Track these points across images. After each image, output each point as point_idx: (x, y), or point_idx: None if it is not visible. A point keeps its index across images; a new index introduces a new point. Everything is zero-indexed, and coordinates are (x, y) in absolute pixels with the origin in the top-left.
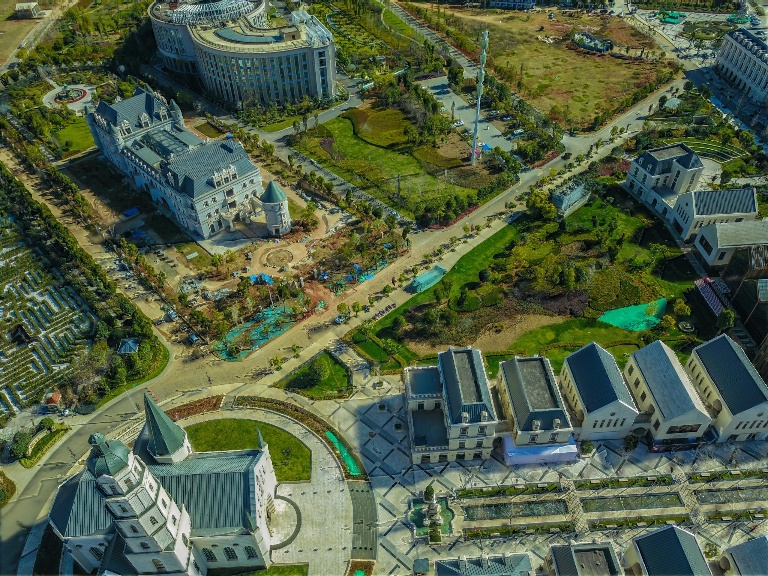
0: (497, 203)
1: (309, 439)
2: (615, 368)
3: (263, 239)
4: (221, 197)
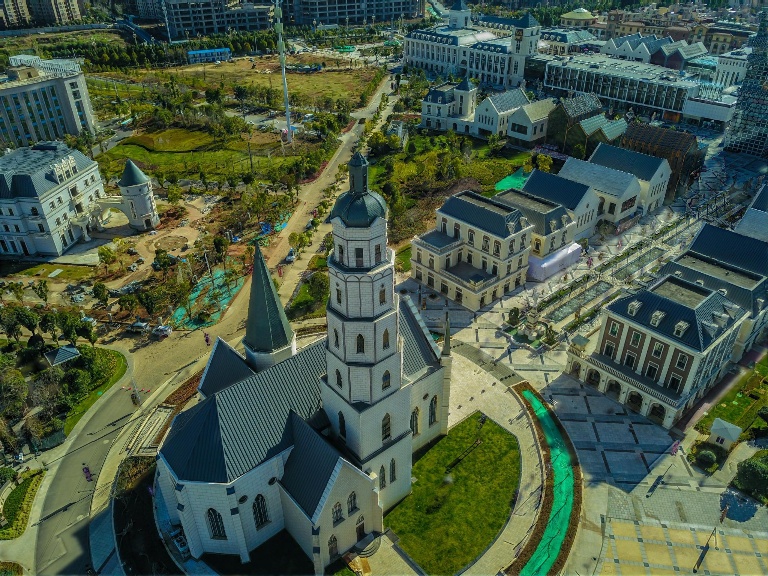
0: (340, 157)
1: None
2: None
3: (135, 236)
4: (66, 197)
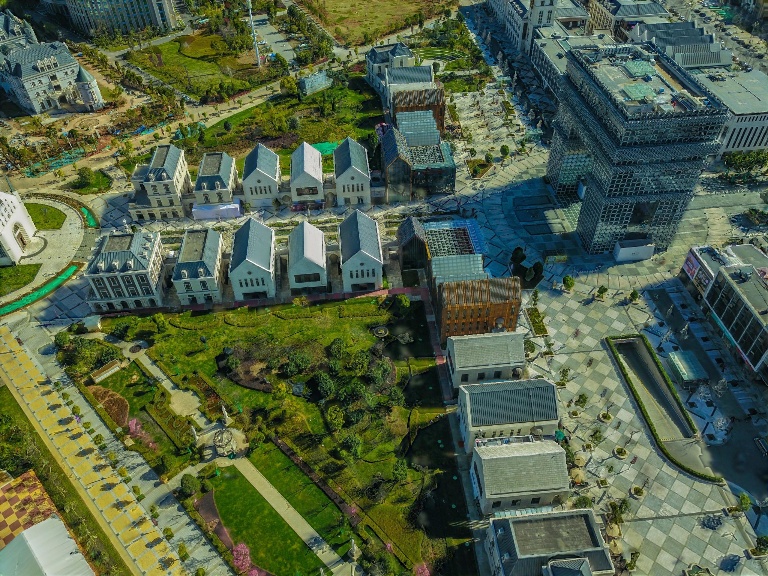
0: (265, 89)
1: (68, 211)
2: (274, 160)
3: (81, 113)
4: (46, 81)
